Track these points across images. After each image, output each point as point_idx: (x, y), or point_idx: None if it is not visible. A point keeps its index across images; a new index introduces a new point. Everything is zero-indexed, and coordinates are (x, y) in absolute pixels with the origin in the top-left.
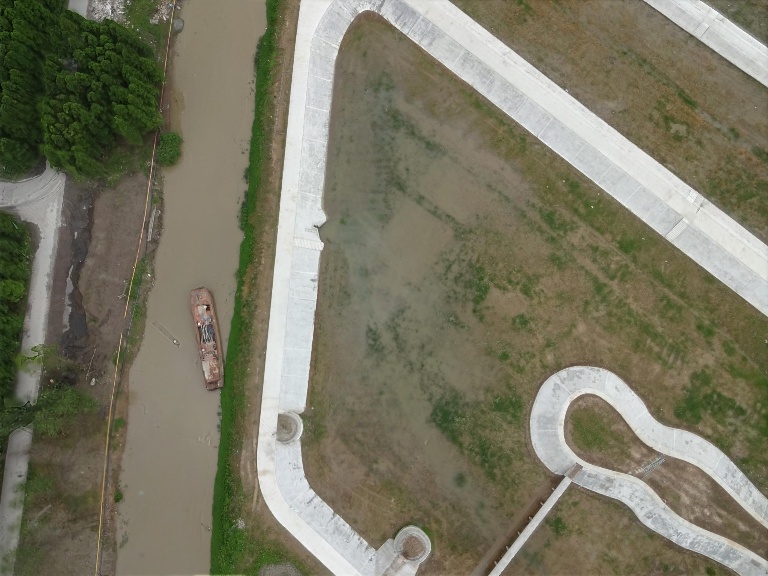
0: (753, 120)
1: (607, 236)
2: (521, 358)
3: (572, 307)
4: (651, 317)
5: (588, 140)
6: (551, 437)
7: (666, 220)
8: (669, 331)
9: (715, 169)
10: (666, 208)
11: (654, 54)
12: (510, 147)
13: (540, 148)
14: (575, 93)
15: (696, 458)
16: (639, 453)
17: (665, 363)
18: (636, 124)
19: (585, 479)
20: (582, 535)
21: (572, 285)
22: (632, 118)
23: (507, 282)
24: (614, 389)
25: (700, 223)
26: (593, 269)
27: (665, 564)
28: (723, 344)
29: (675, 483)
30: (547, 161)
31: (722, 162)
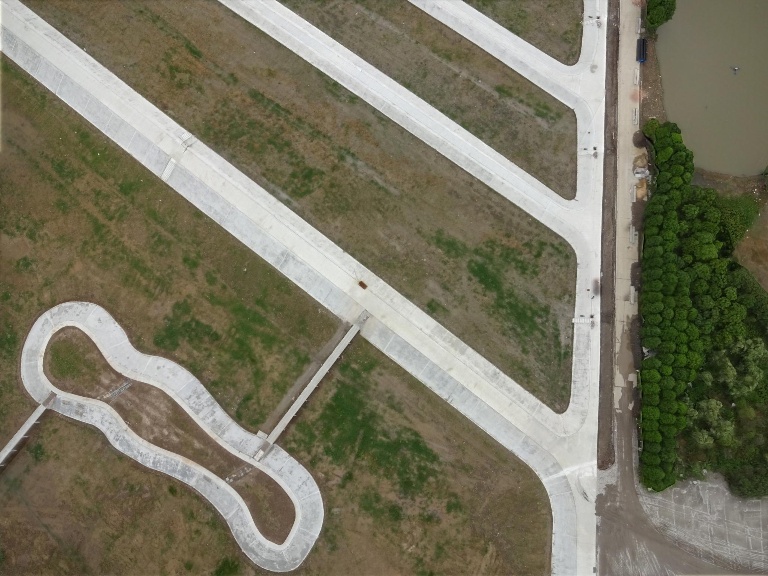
0: (251, 64)
1: (110, 180)
2: (20, 297)
3: (71, 248)
4: (142, 253)
5: (92, 92)
6: (33, 368)
7: (159, 161)
8: (158, 265)
9: (212, 112)
10: (157, 150)
11: (167, 10)
12: (31, 104)
13: (58, 104)
14: (92, 51)
15: (161, 381)
16: (108, 379)
17: (151, 295)
18: (144, 75)
19: (62, 406)
20: (58, 460)
21: (74, 227)
22: (141, 70)
23: (15, 228)
24: (96, 321)
25: (186, 162)
26: (94, 211)
27: (132, 484)
28: (206, 274)
29: (139, 406)
30: (63, 115)
31: (219, 105)
